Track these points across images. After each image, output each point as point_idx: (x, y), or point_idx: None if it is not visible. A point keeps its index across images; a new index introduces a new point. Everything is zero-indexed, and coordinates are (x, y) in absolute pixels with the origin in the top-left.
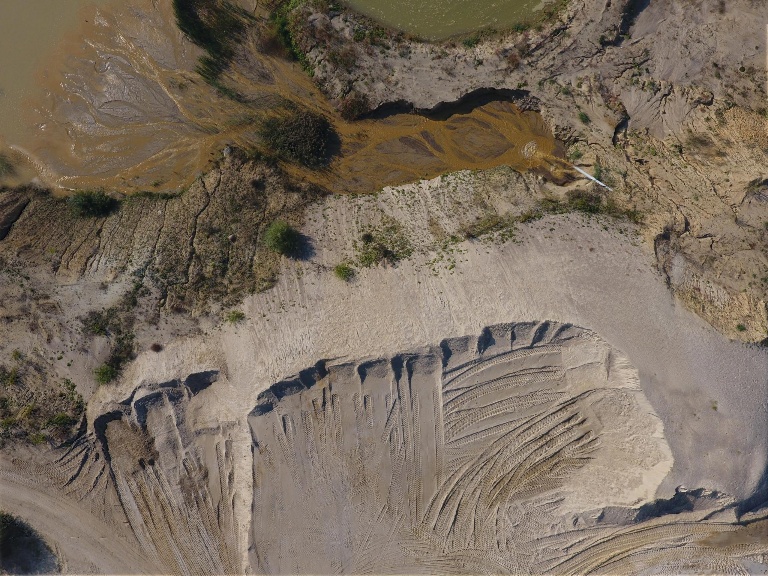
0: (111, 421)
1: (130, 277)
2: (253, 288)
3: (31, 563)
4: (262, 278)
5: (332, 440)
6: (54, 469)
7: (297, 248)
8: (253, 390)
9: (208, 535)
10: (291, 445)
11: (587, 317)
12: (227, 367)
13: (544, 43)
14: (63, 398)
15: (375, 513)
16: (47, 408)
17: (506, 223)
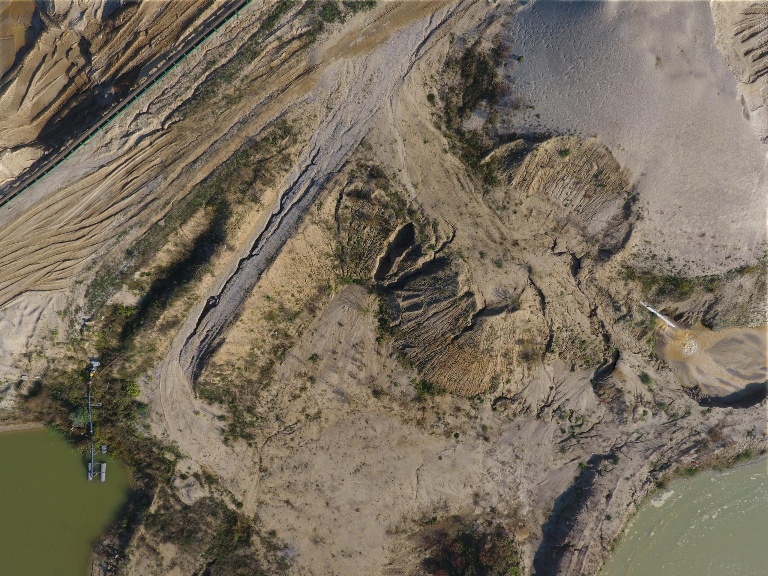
0: None
1: None
2: None
3: None
4: None
5: None
6: None
7: None
8: None
9: None
10: None
11: (760, 157)
12: None
13: (680, 455)
14: None
15: None
16: None
17: (763, 266)
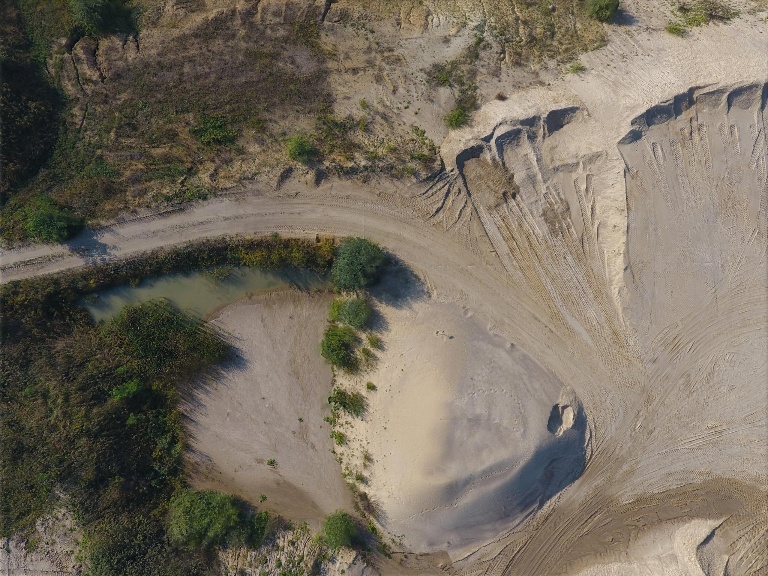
0: (469, 159)
1: (472, 31)
2: (585, 47)
3: (400, 290)
4: (592, 39)
5: (701, 166)
6: (419, 202)
7: (617, 17)
8: (623, 118)
9: (575, 263)
10: (661, 171)
11: None
12: (585, 105)
13: None
14: (415, 142)
15: (745, 236)
16: (404, 148)
17: None
